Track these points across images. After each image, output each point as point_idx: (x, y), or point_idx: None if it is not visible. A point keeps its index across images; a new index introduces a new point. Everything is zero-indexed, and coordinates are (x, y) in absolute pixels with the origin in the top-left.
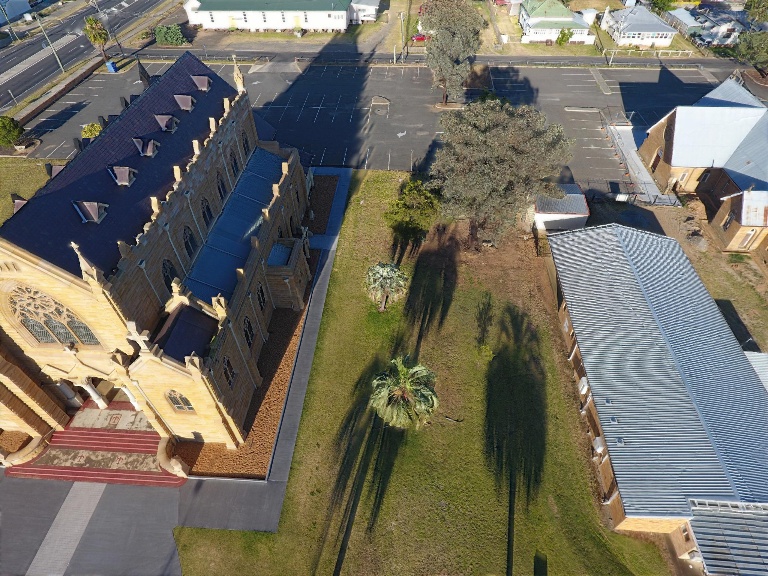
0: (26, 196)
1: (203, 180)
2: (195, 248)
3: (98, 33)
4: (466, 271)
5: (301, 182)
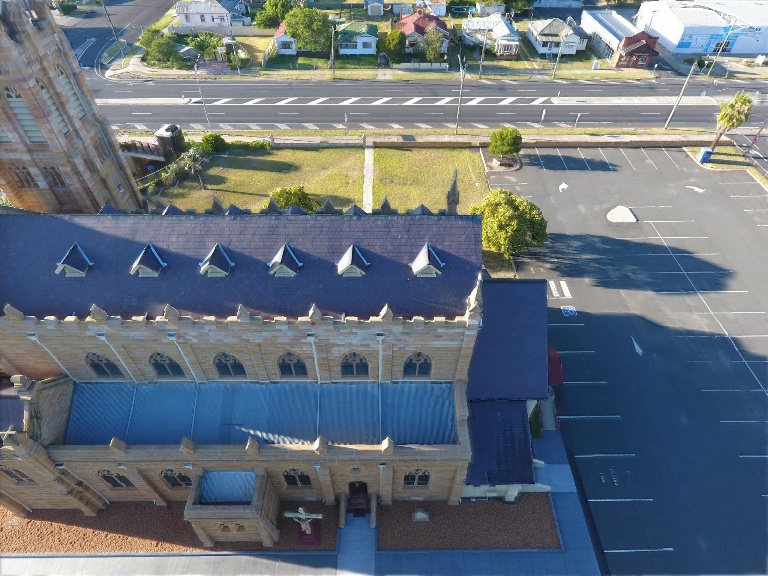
0: (422, 197)
1: (234, 342)
2: (180, 375)
3: (733, 115)
4: None
5: (452, 478)
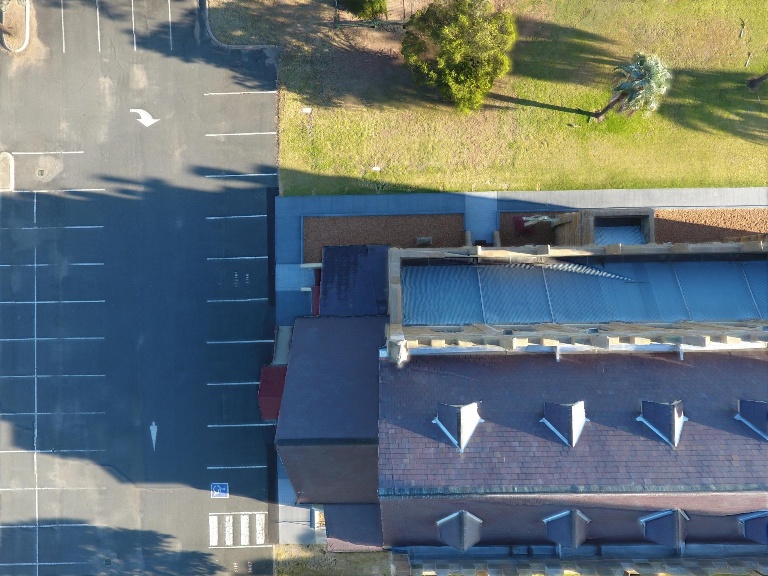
0: None
1: None
2: None
3: None
4: (518, 8)
5: None
